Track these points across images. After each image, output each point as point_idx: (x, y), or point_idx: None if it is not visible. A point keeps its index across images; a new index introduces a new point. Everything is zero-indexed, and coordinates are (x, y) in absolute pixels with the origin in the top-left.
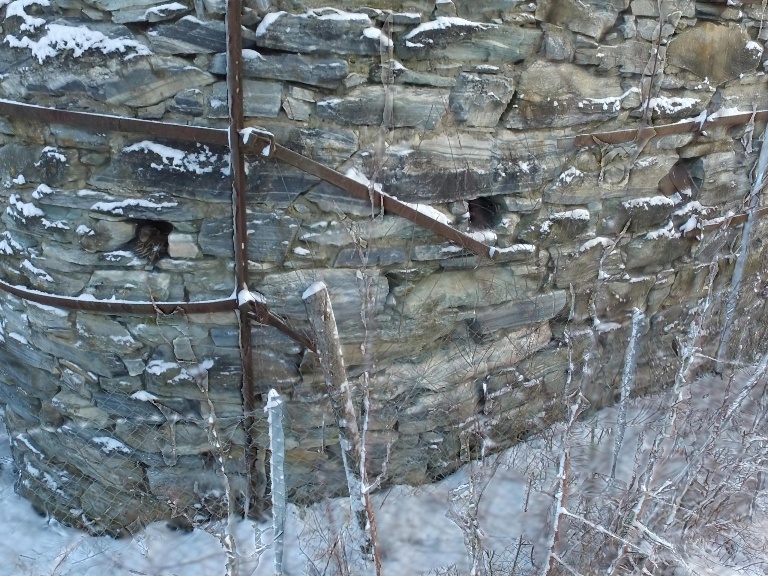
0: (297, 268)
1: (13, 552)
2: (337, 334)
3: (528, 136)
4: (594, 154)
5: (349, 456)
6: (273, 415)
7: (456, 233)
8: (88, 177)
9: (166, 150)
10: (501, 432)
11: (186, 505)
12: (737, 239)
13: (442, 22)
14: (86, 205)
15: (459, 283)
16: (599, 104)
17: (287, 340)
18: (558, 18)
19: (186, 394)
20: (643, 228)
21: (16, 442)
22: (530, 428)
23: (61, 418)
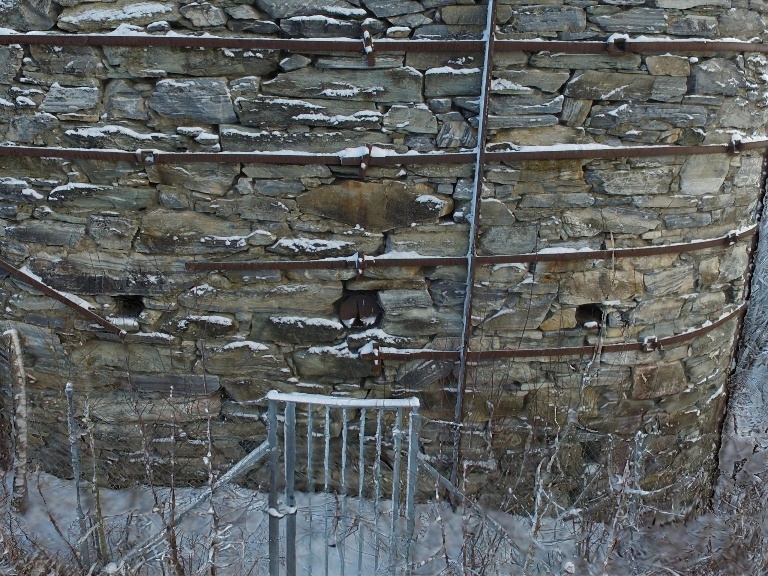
0: (9, 319)
1: None
2: (19, 363)
3: (158, 258)
4: (225, 276)
5: None
6: None
7: (94, 316)
8: None
9: None
10: None
11: None
12: (464, 375)
13: (69, 186)
14: None
15: (115, 350)
16: (221, 240)
17: None
18: (173, 181)
19: None
20: (311, 342)
21: None
22: (205, 479)
23: None
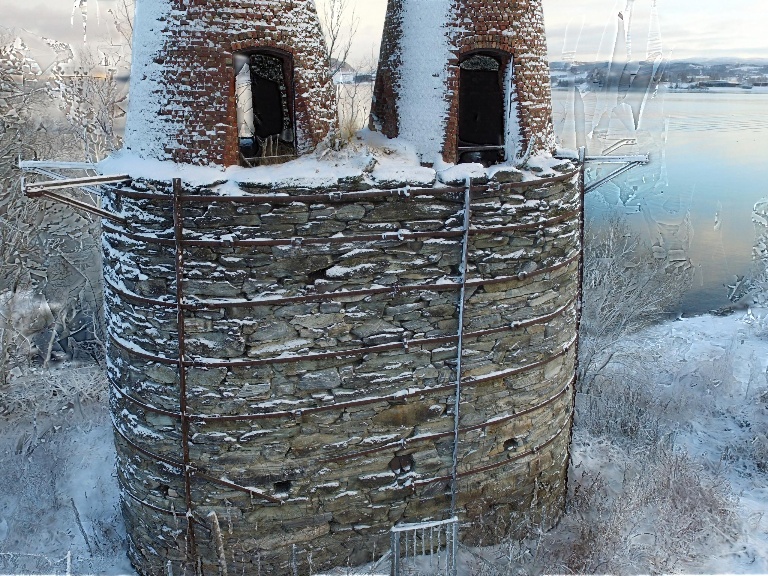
0: (207, 505)
1: None
2: (219, 529)
3: (300, 460)
4: (336, 462)
5: (221, 573)
6: (169, 567)
7: (266, 496)
8: None
9: (168, 465)
10: (304, 568)
11: None
12: None
13: (253, 433)
14: (146, 475)
15: (274, 511)
16: (335, 445)
17: None
18: (308, 421)
19: None
20: (379, 485)
21: None
22: (322, 568)
23: None
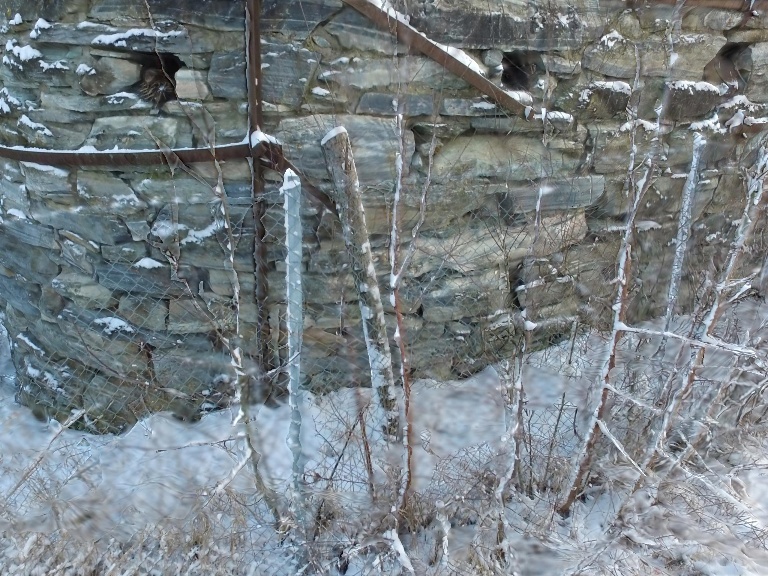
0: (315, 112)
1: (11, 451)
2: None
3: None
4: (638, 19)
5: (370, 325)
6: (290, 200)
7: (489, 85)
8: (89, 9)
9: None
10: None
11: (193, 392)
12: None
13: None
14: (87, 39)
15: (491, 150)
16: None
17: (304, 199)
18: None
19: (194, 261)
20: (687, 118)
21: (16, 343)
22: (563, 332)
23: (62, 305)
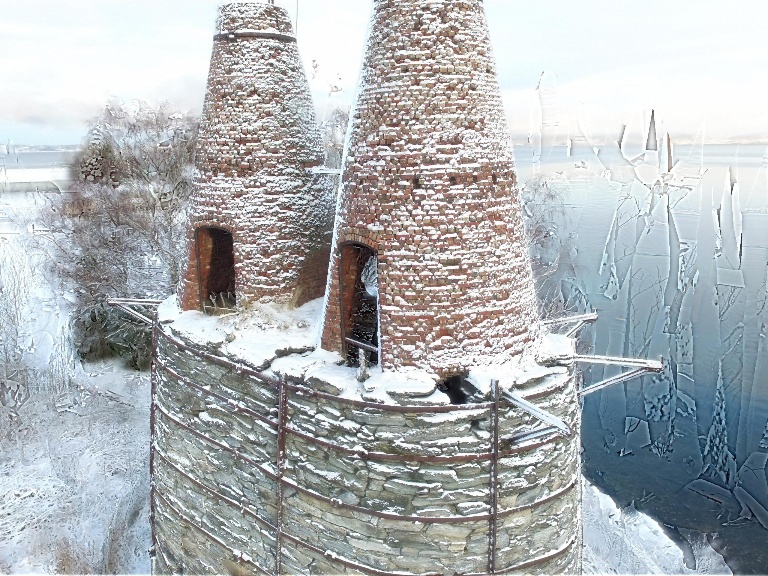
0: None
1: None
2: (154, 573)
3: None
4: None
5: None
6: None
7: None
8: None
9: None
10: None
11: None
12: None
13: None
14: None
15: None
16: None
17: None
18: None
19: None
20: None
21: None
22: None
23: None
